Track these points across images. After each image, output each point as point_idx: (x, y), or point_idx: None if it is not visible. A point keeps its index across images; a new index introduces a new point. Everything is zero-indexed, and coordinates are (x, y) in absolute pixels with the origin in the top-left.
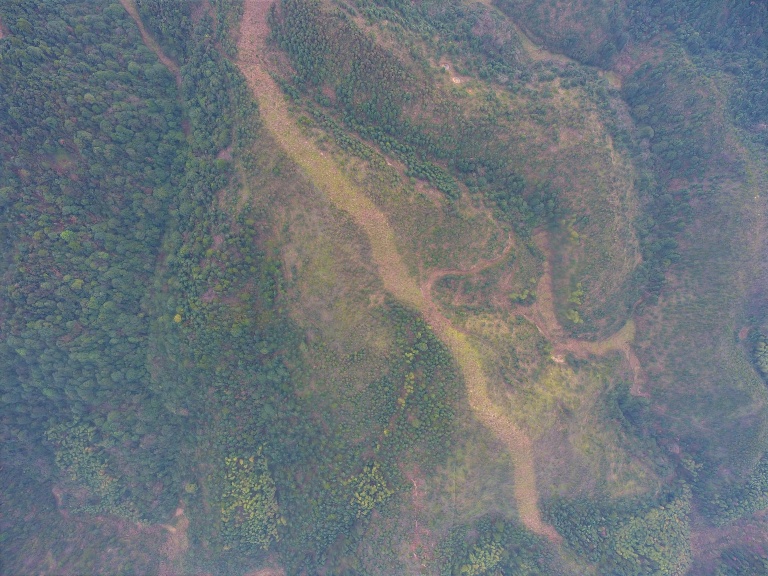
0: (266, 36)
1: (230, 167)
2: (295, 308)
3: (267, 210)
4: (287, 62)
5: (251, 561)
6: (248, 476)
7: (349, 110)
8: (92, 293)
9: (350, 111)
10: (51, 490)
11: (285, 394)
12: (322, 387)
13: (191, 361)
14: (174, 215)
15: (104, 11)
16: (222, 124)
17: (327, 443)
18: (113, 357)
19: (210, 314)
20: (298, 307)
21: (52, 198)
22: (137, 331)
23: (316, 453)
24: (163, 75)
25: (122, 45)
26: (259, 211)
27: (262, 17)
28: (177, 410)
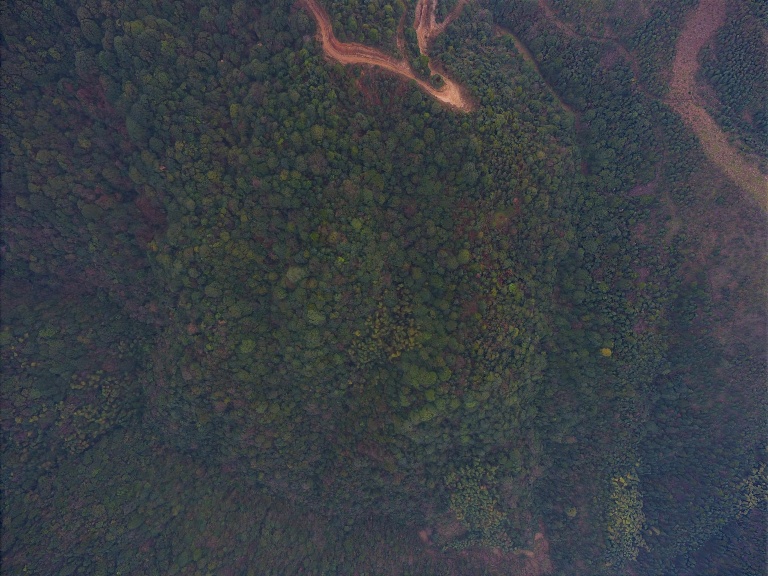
0: (695, 73)
1: (657, 202)
2: (721, 327)
3: (699, 238)
4: (715, 94)
5: (620, 574)
6: (624, 493)
7: (765, 131)
8: (523, 339)
9: (766, 132)
10: (416, 532)
11: (678, 410)
12: (735, 398)
13: (612, 391)
14: (582, 254)
15: (524, 70)
16: (648, 162)
17: (722, 451)
18: (522, 397)
19: (645, 344)
20: (725, 326)
21: (497, 255)
22: (541, 369)
23: (701, 462)
24: (573, 122)
25: (540, 99)
26: (695, 240)
27: (694, 55)
28: (562, 439)
